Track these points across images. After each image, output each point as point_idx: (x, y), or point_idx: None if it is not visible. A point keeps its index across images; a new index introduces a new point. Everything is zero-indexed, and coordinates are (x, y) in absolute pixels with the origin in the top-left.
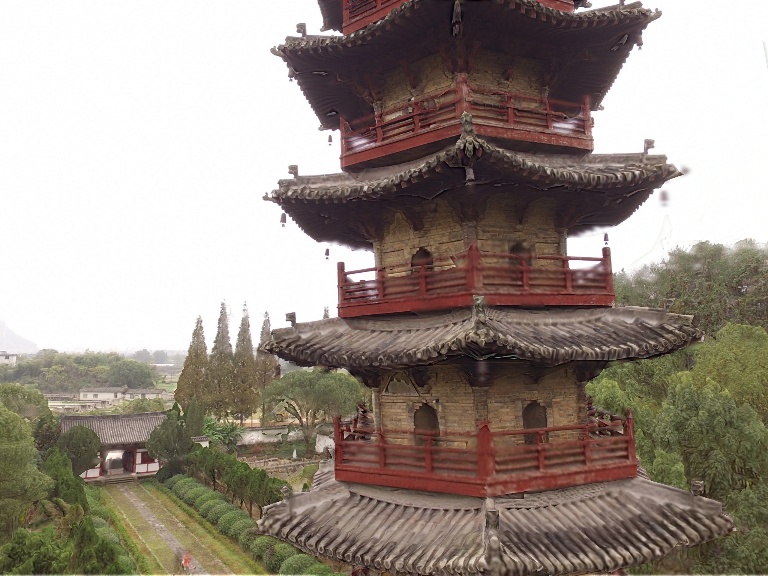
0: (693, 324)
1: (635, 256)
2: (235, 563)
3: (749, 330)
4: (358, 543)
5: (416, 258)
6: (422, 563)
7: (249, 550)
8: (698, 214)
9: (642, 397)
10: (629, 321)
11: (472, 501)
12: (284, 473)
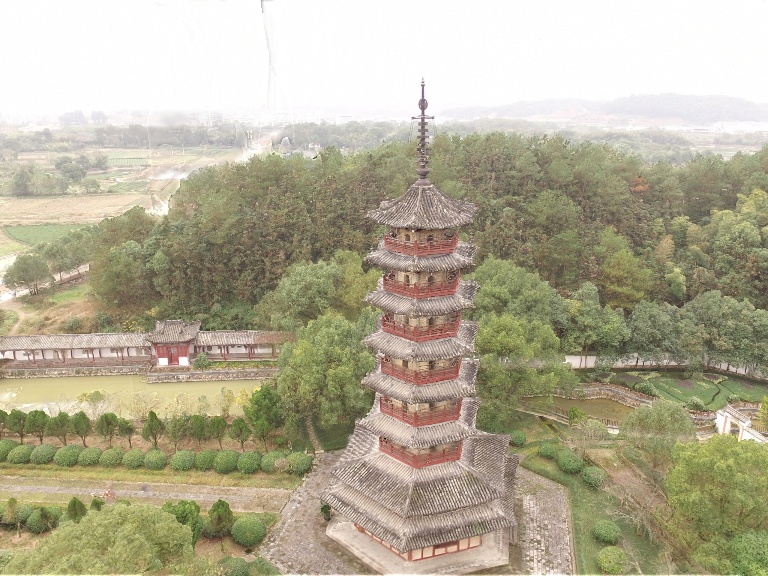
0: (291, 227)
1: (154, 104)
2: (127, 477)
3: (351, 254)
4: (436, 440)
5: (430, 362)
6: (457, 438)
7: (119, 466)
8: (205, 73)
9: (326, 307)
10: (466, 363)
11: (453, 420)
12: (43, 403)
